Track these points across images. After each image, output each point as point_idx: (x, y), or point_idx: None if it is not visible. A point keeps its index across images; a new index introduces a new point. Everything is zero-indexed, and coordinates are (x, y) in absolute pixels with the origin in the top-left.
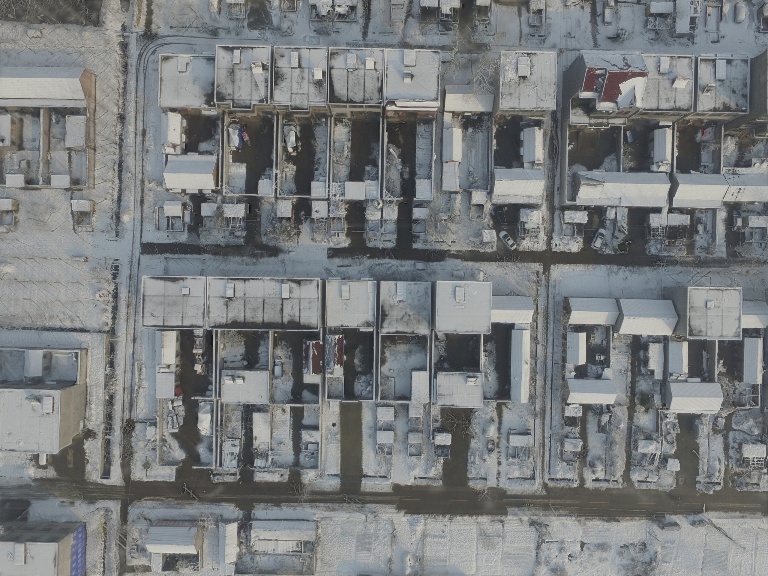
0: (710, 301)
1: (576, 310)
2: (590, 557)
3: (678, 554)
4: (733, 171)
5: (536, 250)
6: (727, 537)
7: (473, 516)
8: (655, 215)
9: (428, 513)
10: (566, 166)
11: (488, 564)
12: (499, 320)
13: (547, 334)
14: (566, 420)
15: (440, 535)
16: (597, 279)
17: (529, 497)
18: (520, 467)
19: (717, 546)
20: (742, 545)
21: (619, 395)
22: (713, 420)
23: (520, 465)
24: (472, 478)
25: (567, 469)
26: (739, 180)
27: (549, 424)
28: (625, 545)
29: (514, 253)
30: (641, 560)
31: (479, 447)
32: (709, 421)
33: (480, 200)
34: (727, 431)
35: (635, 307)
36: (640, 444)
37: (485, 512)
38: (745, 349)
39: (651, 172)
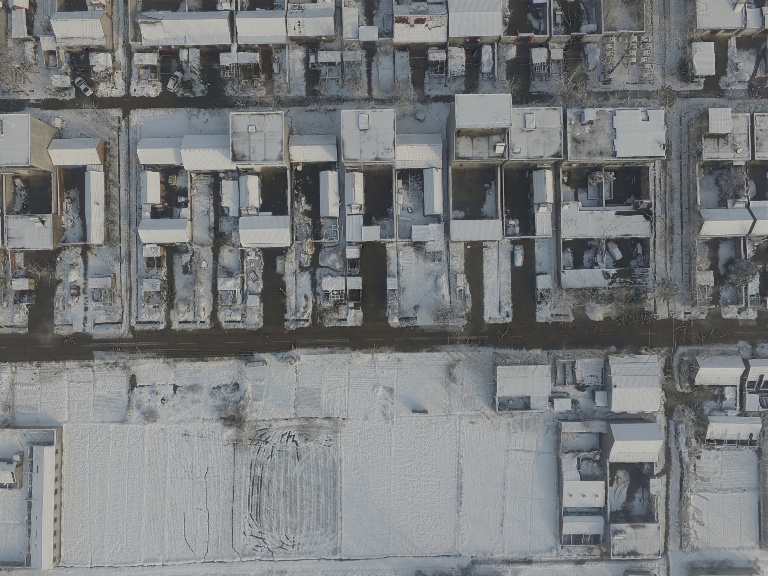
0: (251, 125)
1: (141, 148)
2: (182, 399)
3: (269, 392)
4: (299, 7)
5: (115, 96)
6: (290, 363)
7: (60, 362)
8: (225, 54)
9: (15, 361)
10: (128, 7)
11: (80, 410)
12: (67, 162)
13: (129, 179)
14: (152, 263)
15: (30, 383)
16: (178, 122)
17: (115, 341)
18: (106, 311)
19: (310, 383)
20: (334, 381)
21: (202, 236)
22: (299, 258)
23: (107, 310)
24: (60, 325)
25: (152, 311)
26: (300, 14)
27: (135, 268)
28: (218, 386)
29: (92, 99)
30: (233, 400)
31: (65, 294)
32: (296, 259)
33: (50, 46)
34: (314, 268)
35: (195, 141)
36: (219, 281)
37: (72, 357)
38: (320, 183)
39: (216, 11)
